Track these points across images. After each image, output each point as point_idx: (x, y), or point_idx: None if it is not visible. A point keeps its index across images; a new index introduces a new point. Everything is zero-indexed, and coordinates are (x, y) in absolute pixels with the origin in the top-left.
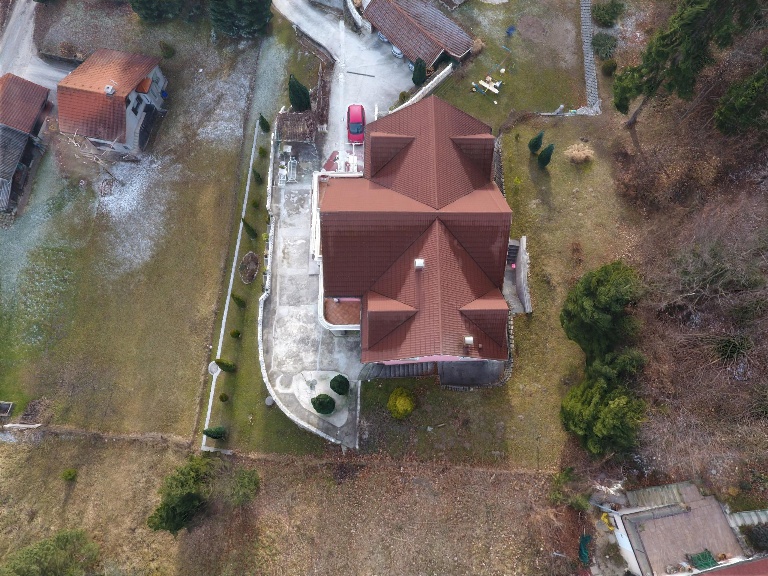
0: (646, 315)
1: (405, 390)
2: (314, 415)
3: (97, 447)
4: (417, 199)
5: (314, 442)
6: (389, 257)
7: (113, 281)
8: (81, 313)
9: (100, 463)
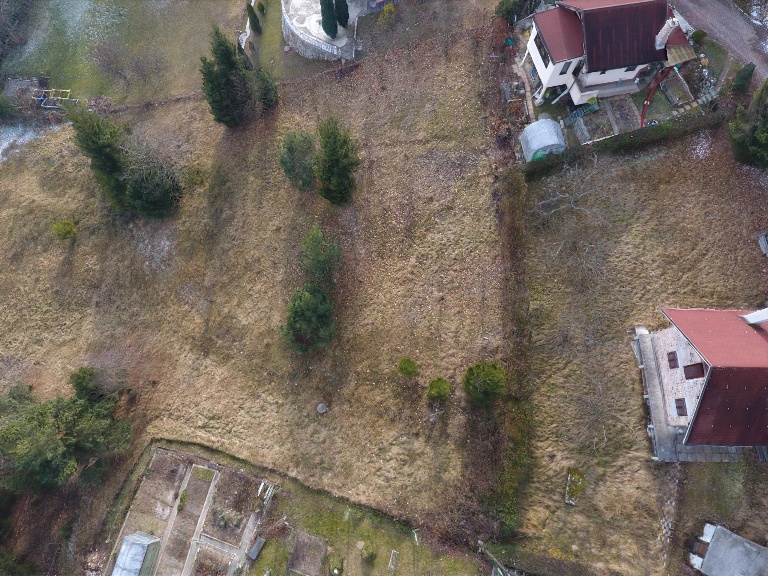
0: None
1: None
2: (321, 40)
3: (149, 111)
4: None
5: (321, 65)
6: None
7: (161, 9)
8: (134, 36)
9: (152, 118)
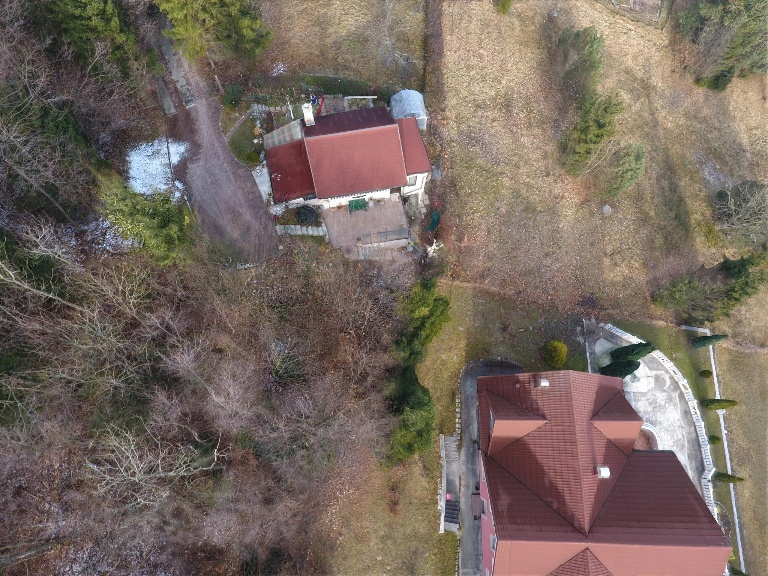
0: (380, 395)
1: (554, 365)
2: None
3: None
4: (607, 571)
5: None
6: (623, 492)
7: None
8: None
9: None
